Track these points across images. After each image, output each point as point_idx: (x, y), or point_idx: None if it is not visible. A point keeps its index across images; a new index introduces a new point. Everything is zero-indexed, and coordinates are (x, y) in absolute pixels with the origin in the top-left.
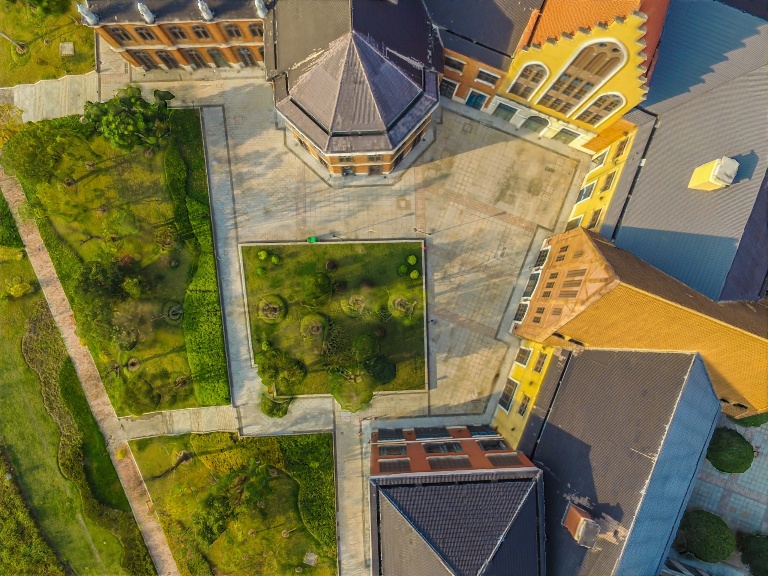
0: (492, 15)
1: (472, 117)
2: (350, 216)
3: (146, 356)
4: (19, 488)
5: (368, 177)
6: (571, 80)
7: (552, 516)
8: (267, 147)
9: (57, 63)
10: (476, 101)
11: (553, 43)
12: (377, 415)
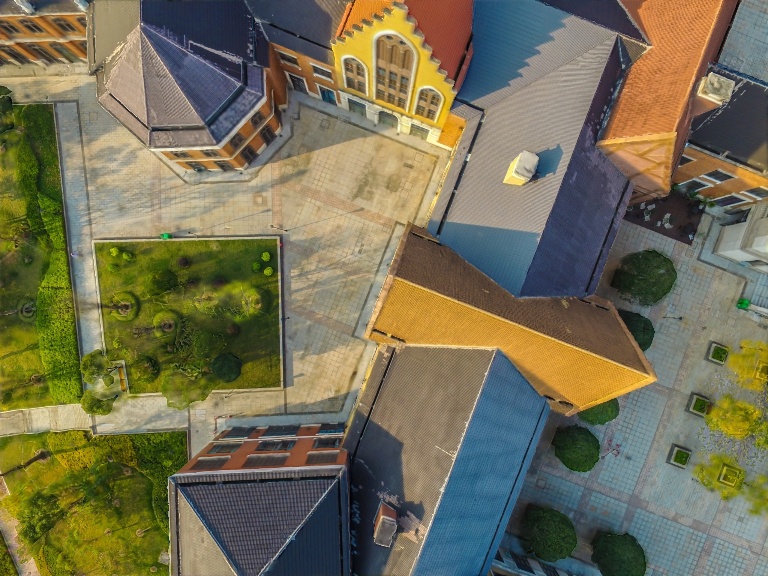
0: (309, 8)
1: (330, 113)
2: (206, 212)
3: (2, 354)
4: None
5: (224, 173)
6: (388, 74)
7: (366, 514)
8: (122, 143)
9: None
10: (330, 96)
11: (350, 36)
12: (233, 413)
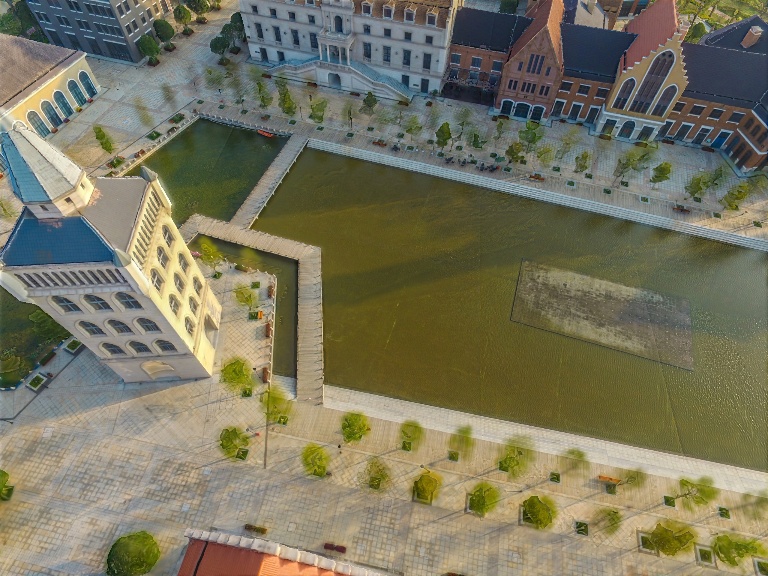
0: None
1: None
2: None
3: None
4: (766, 13)
5: None
6: None
7: None
8: None
9: None
10: None
11: None
12: None
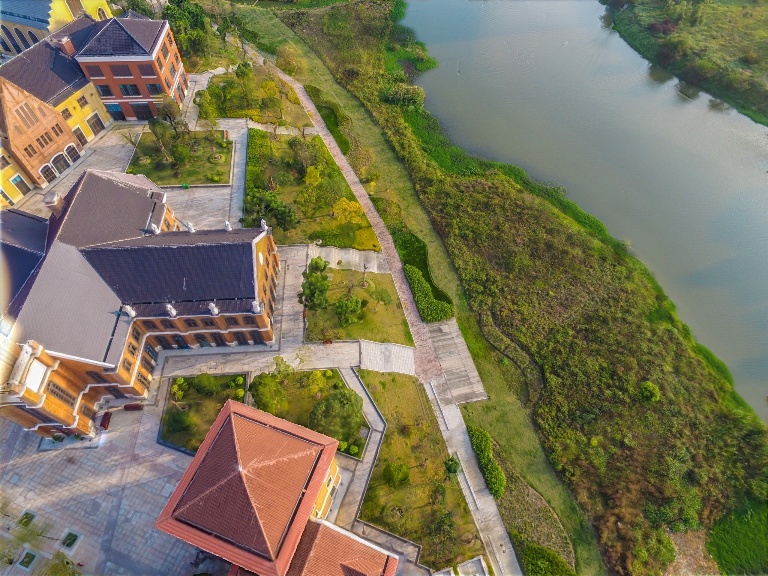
0: (7, 218)
1: None
2: None
3: None
4: (370, 112)
5: None
6: None
7: None
8: None
9: (338, 274)
10: None
11: None
12: None
